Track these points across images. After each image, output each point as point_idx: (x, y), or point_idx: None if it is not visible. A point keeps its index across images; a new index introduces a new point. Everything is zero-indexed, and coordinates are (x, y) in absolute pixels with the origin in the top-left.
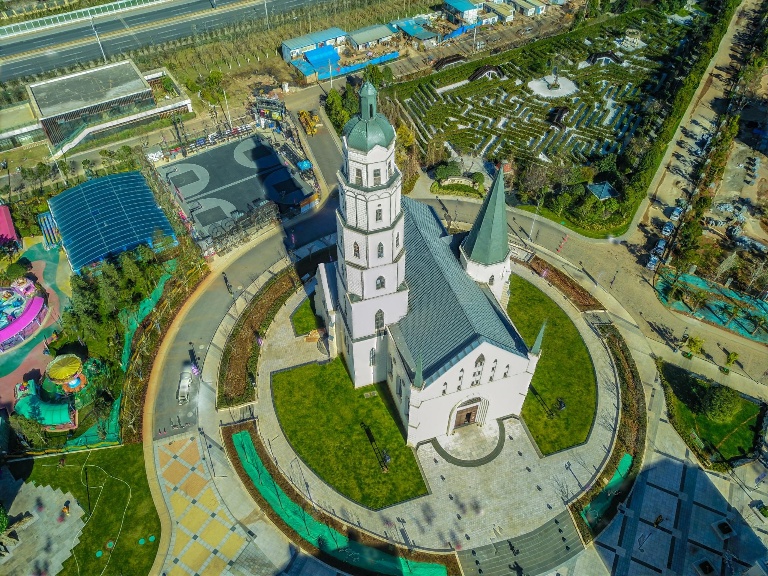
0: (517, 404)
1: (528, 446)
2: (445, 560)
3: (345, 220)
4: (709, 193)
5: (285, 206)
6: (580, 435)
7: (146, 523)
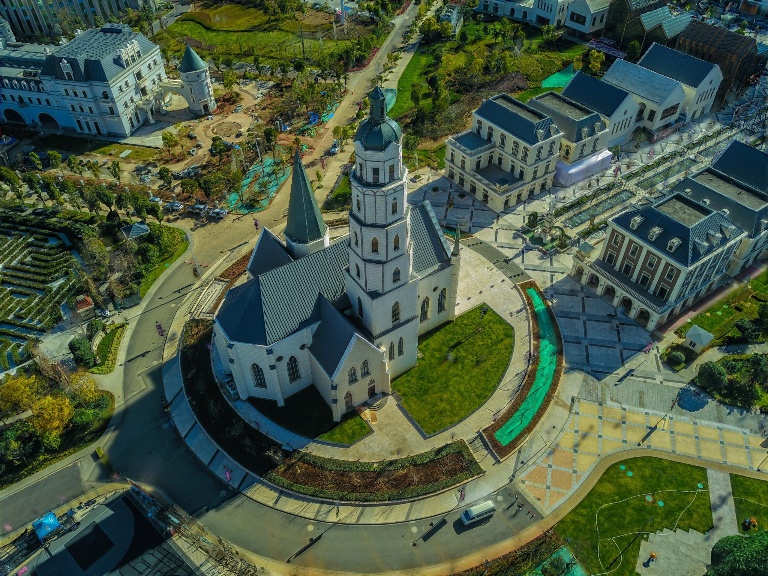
0: None
1: None
2: (524, 288)
3: (400, 218)
4: (126, 185)
5: (140, 530)
6: None
7: (615, 478)
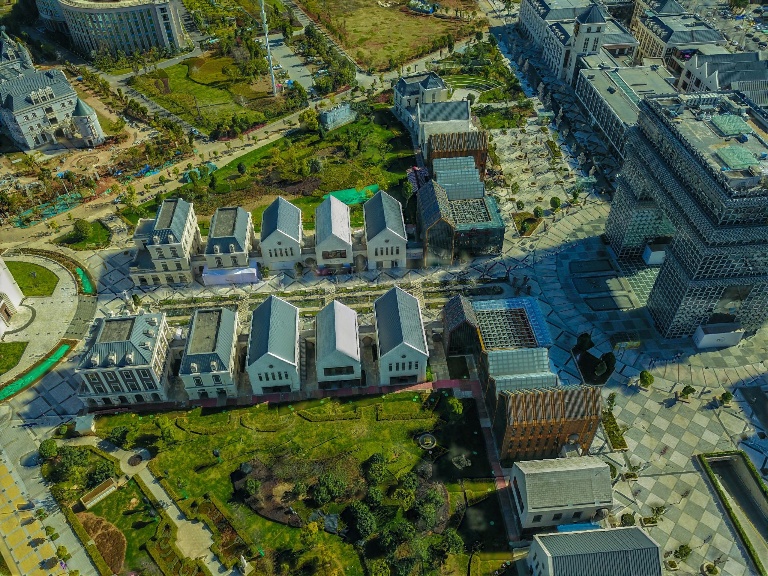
0: (18, 291)
1: (42, 299)
2: (61, 343)
3: None
4: None
5: None
6: (54, 280)
7: None
